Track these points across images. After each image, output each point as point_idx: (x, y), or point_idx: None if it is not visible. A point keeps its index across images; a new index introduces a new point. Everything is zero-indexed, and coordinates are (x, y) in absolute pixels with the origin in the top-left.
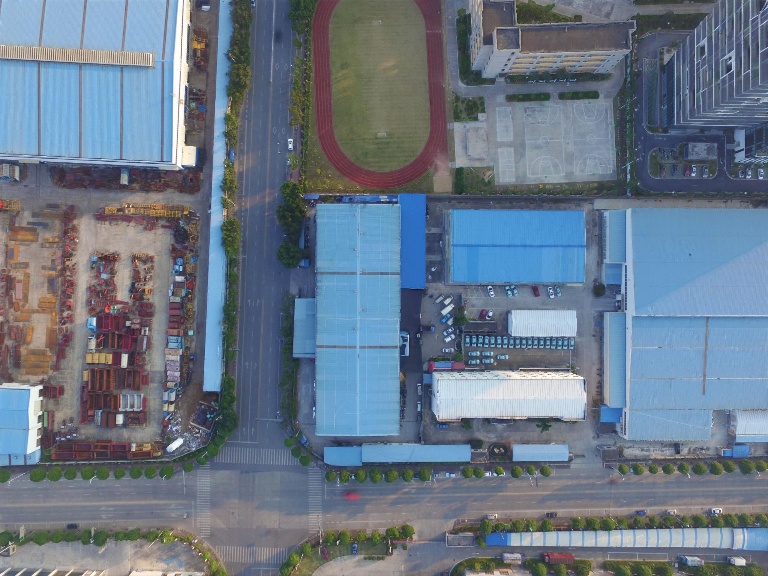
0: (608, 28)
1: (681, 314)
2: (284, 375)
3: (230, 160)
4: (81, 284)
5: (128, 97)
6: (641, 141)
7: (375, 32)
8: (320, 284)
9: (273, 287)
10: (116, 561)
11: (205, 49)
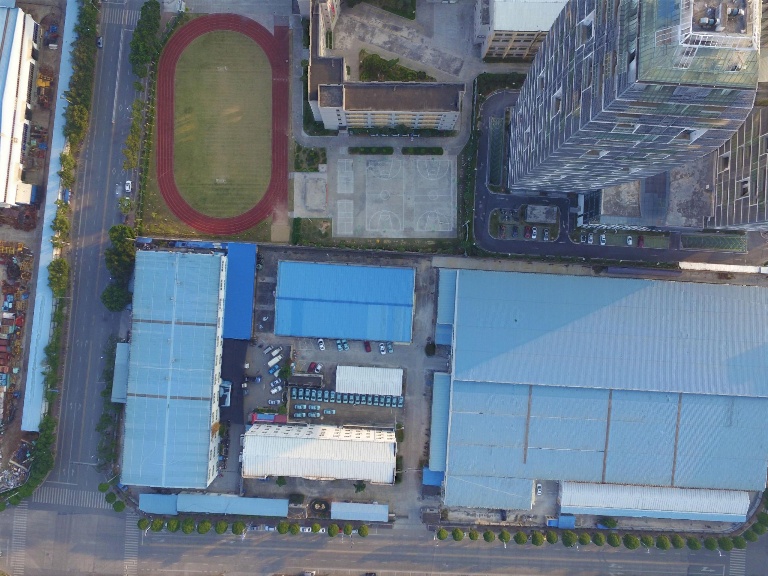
0: (438, 89)
1: (502, 381)
2: (101, 419)
3: (64, 200)
4: None
5: None
6: (482, 200)
7: (221, 78)
8: (135, 331)
9: (102, 328)
10: None
11: (50, 87)
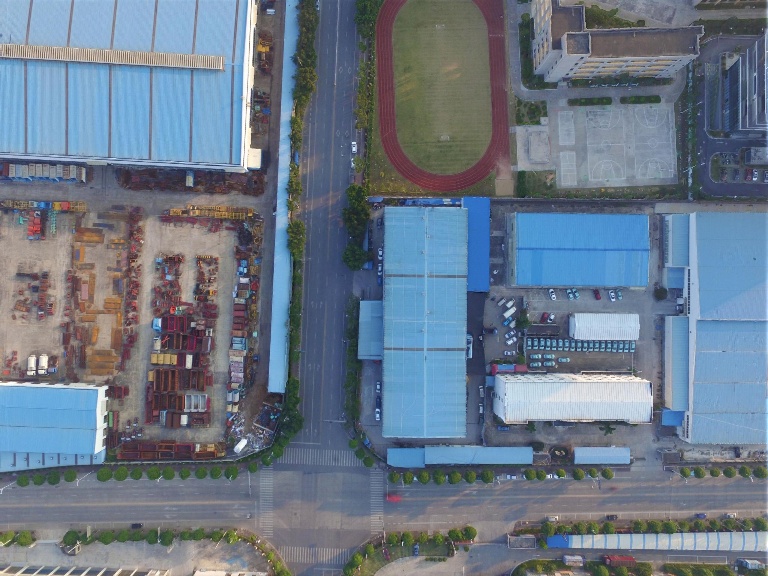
0: (676, 33)
1: (746, 318)
2: (349, 377)
3: (295, 163)
4: (146, 285)
5: (198, 100)
6: (702, 145)
7: (438, 36)
8: (388, 286)
9: (336, 289)
10: (180, 561)
11: (269, 52)
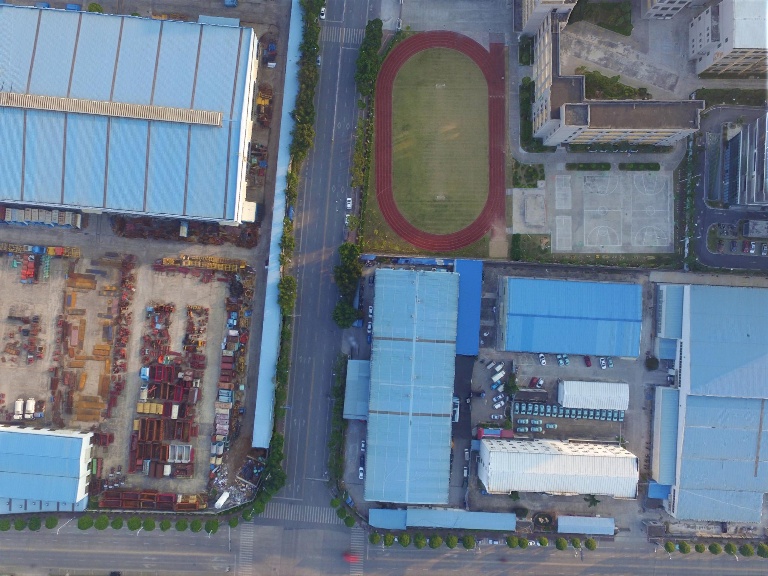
0: (676, 106)
1: (737, 396)
2: (333, 435)
3: (289, 218)
4: (136, 333)
5: (194, 154)
6: (700, 215)
7: (438, 95)
8: (376, 349)
9: (325, 345)
10: None
11: (269, 105)
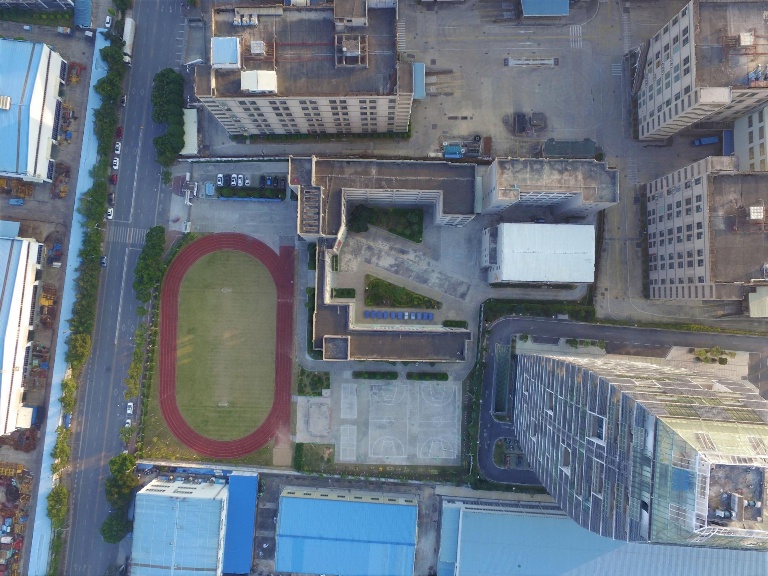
0: (444, 336)
1: None
2: None
3: (64, 426)
4: None
5: None
6: (487, 429)
7: (225, 298)
8: (133, 575)
9: (101, 553)
10: None
11: (53, 306)
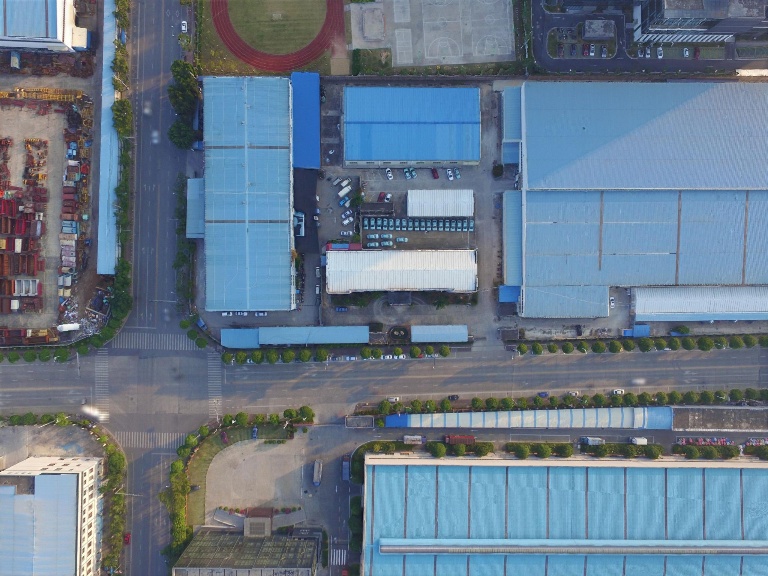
0: None
1: (574, 187)
2: (178, 256)
3: (121, 41)
4: None
5: None
6: (539, 21)
7: None
8: (208, 158)
9: (169, 171)
10: (14, 447)
11: None
